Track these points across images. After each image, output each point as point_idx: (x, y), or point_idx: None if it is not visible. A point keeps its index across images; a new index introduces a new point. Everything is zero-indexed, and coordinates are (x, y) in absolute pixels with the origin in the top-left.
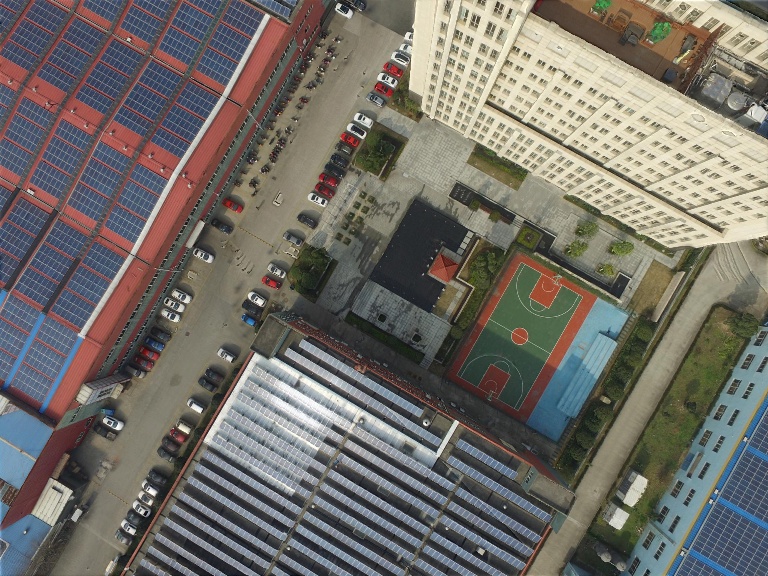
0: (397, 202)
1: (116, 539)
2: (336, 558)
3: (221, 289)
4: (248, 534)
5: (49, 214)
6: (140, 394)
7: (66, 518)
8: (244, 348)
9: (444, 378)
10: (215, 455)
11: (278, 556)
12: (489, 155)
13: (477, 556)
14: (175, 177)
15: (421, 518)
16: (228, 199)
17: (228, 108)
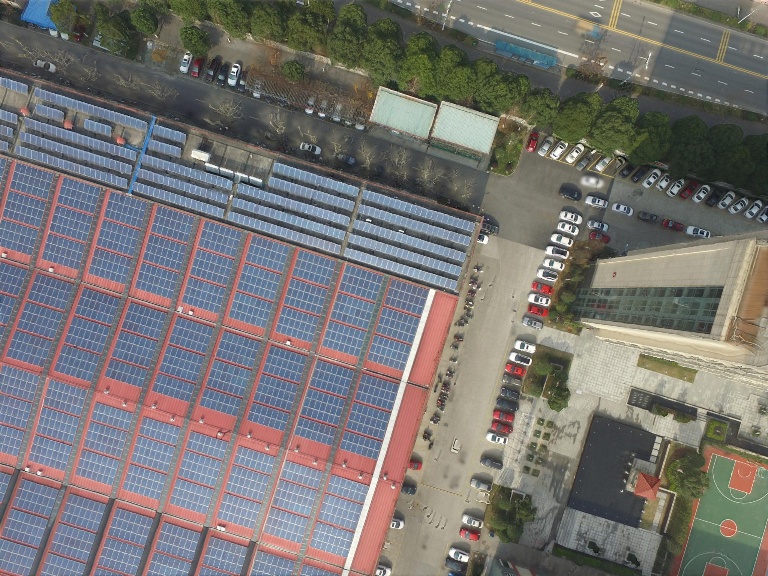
0: (577, 421)
1: None
2: None
3: (418, 552)
4: None
5: (246, 547)
6: None
7: None
8: None
9: None
10: None
11: None
12: None
13: None
14: (376, 481)
15: None
16: None
17: (410, 392)
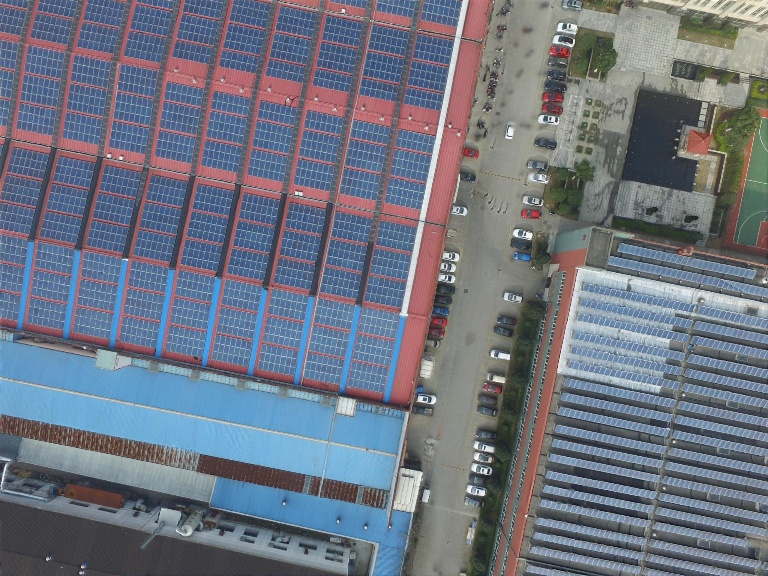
0: (623, 98)
1: (465, 506)
2: (719, 435)
3: (483, 237)
4: (633, 441)
5: (325, 209)
6: (440, 363)
7: None
8: (525, 285)
9: (723, 248)
10: None
11: (665, 452)
12: (697, 24)
13: None
14: (442, 130)
15: None
16: None
17: (465, 48)
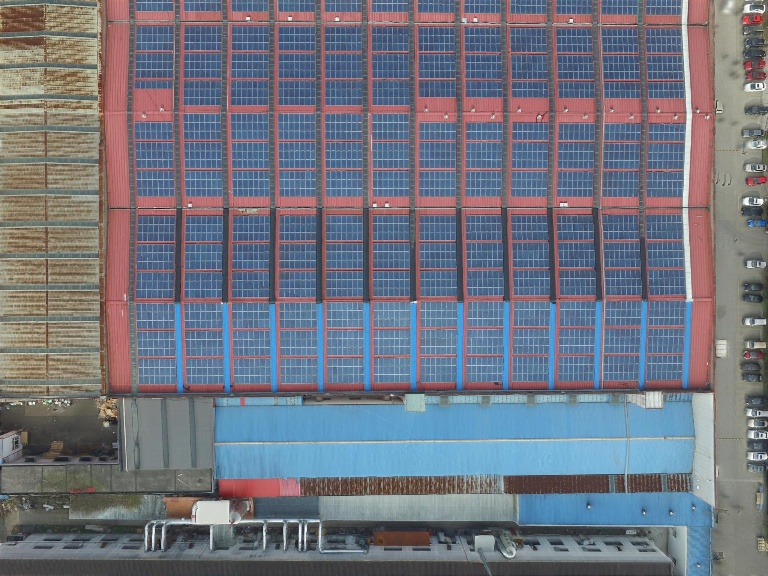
0: None
1: (749, 473)
2: None
3: None
4: None
5: (591, 215)
6: None
7: None
8: (763, 250)
9: None
10: None
11: None
12: None
13: None
14: (690, 117)
15: None
16: None
17: (693, 33)
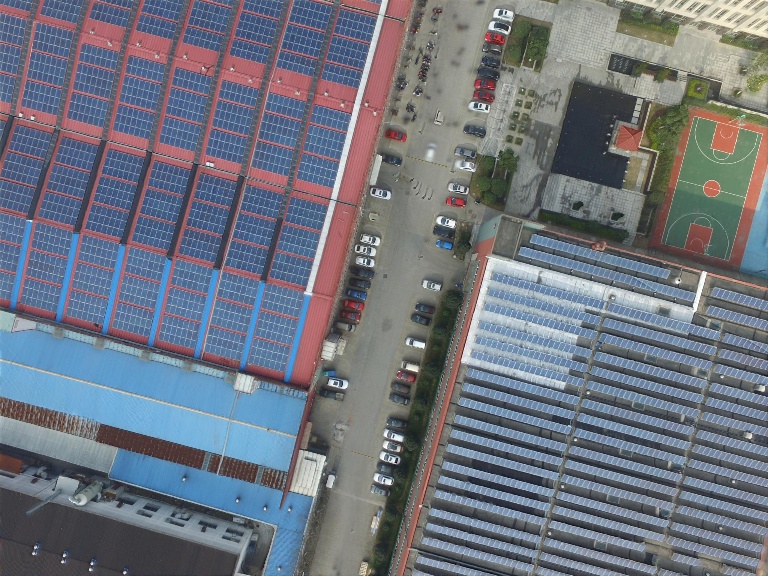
0: (558, 89)
1: (372, 495)
2: (622, 436)
3: (406, 223)
4: (533, 437)
5: (236, 182)
6: (355, 348)
7: (318, 488)
8: (446, 274)
9: (650, 249)
10: (478, 371)
11: (566, 450)
12: (637, 18)
13: (759, 394)
14: (358, 108)
15: (694, 375)
16: (390, 130)
17: (388, 26)
